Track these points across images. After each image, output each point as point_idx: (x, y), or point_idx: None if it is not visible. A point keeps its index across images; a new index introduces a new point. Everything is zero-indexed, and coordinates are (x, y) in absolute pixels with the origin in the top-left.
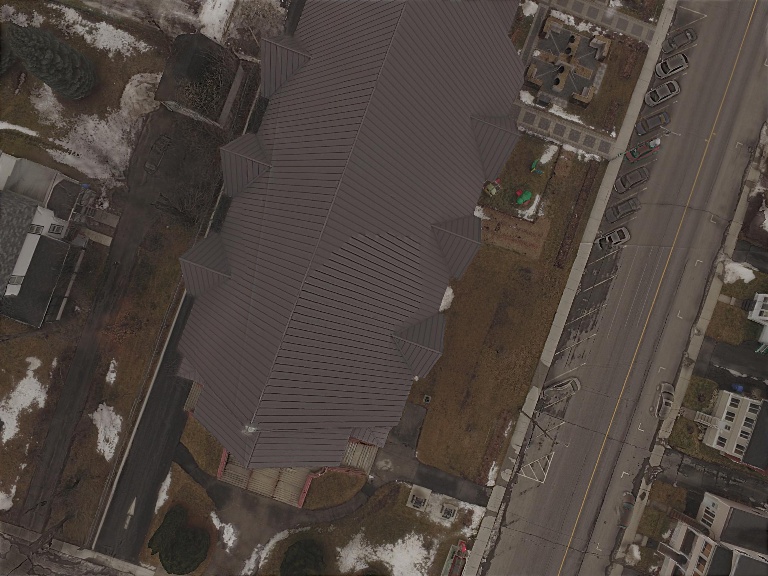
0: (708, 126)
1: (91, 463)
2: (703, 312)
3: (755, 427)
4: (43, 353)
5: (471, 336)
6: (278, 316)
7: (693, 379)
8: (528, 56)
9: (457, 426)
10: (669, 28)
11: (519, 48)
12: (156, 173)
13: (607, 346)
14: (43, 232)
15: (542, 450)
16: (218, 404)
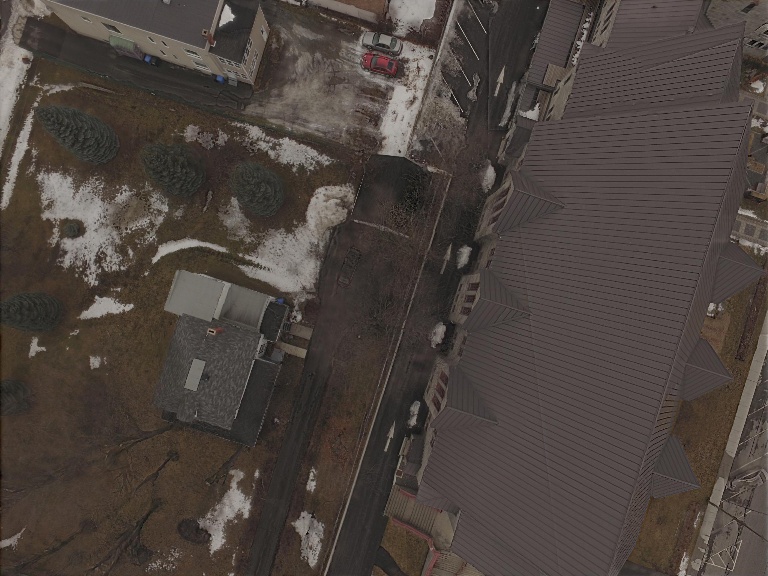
0: None
1: (296, 570)
2: None
3: None
4: (245, 465)
5: None
6: (606, 492)
7: None
8: None
9: (648, 520)
10: None
11: None
12: (349, 286)
13: None
14: (256, 356)
15: (730, 539)
16: (487, 544)
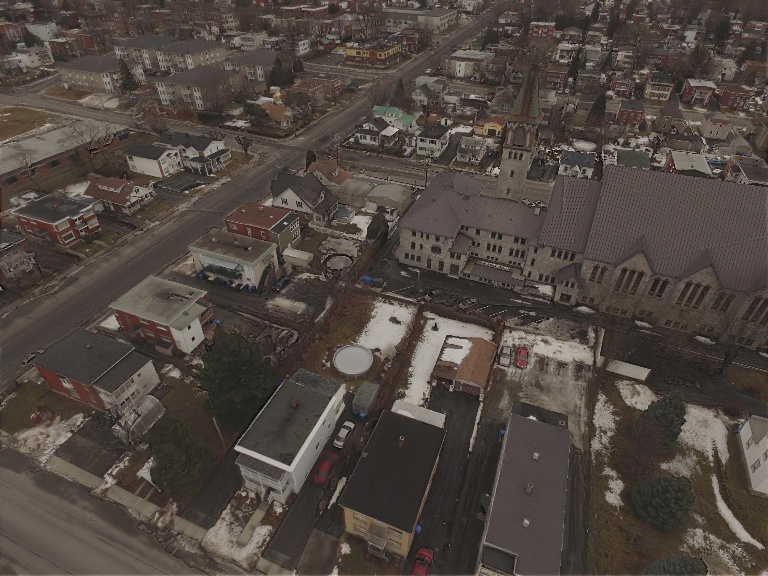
0: None
1: None
2: None
3: None
4: None
5: None
6: None
7: None
8: None
9: None
10: None
11: None
12: None
13: None
14: None
15: None
16: None
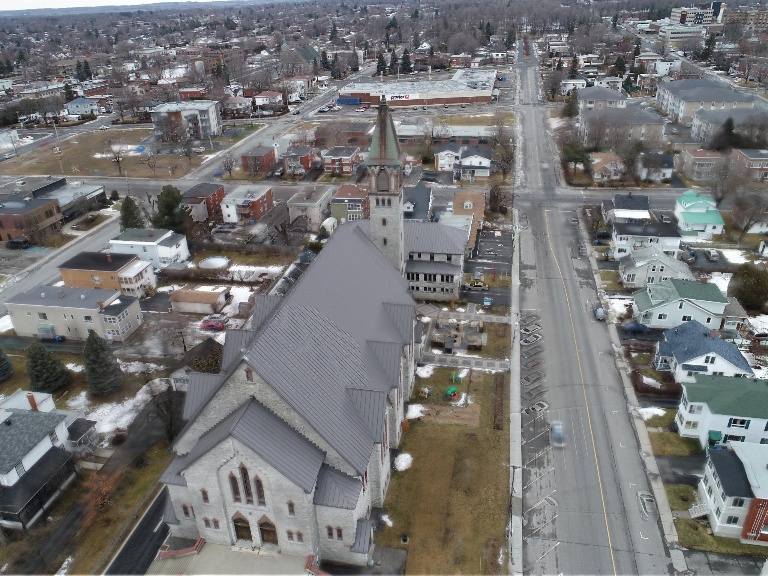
0: (572, 348)
1: None
2: (641, 440)
3: (715, 468)
4: None
5: (436, 484)
6: None
7: (667, 487)
8: (432, 336)
9: (444, 561)
10: (520, 317)
11: (424, 334)
12: (156, 419)
13: (569, 474)
14: (55, 445)
15: (548, 573)
16: None
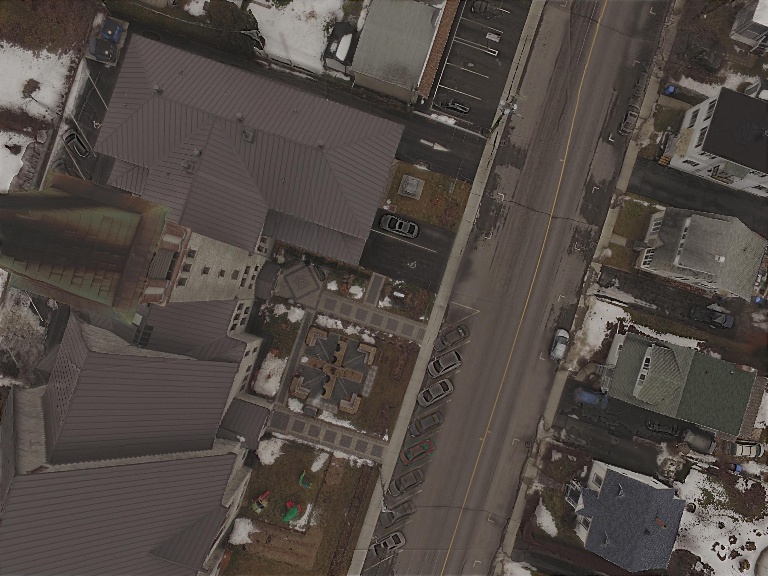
0: (483, 424)
1: None
2: None
3: None
4: None
5: None
6: None
7: None
8: (296, 363)
9: None
10: (441, 325)
11: (286, 355)
12: None
13: None
14: None
15: None
16: None
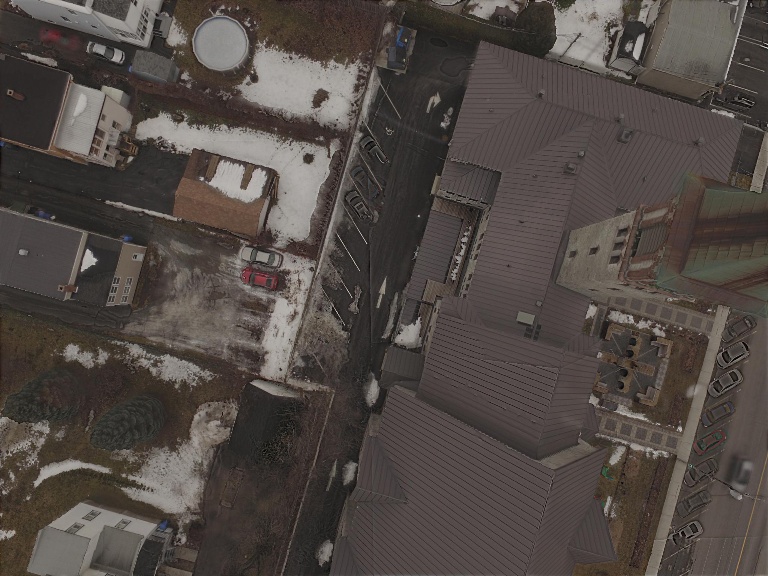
0: None
1: None
2: None
3: None
4: None
5: None
6: None
7: None
8: None
9: None
10: (728, 316)
11: None
12: None
13: None
14: None
15: None
16: None
